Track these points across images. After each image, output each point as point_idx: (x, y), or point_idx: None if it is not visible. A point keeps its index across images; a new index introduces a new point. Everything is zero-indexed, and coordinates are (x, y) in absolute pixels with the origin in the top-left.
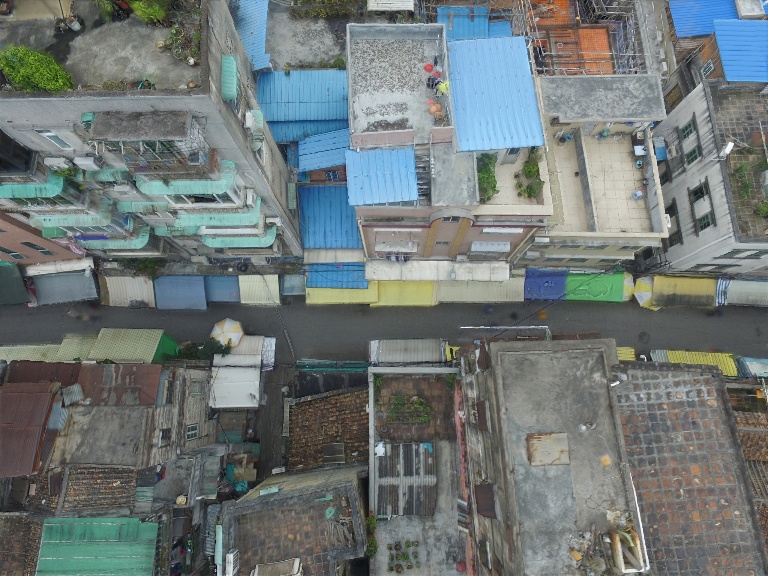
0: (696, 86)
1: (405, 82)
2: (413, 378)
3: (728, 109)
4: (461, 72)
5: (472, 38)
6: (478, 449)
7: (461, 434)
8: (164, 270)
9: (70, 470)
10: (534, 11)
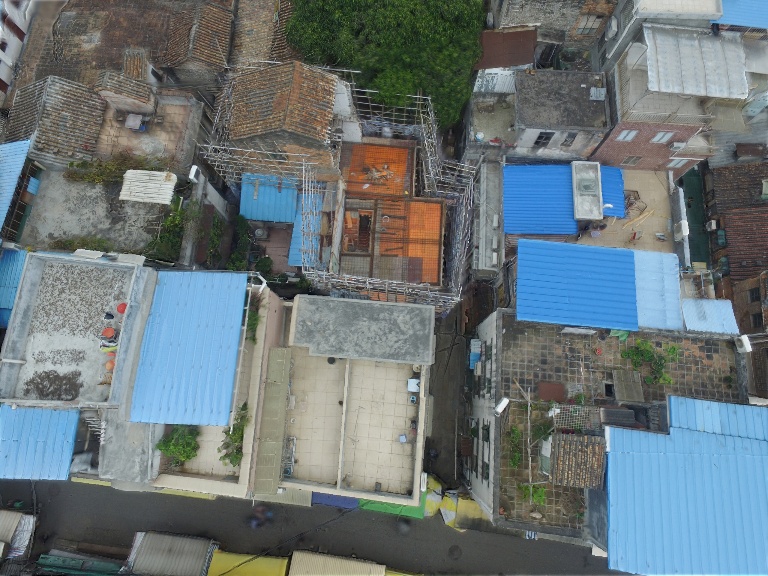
0: (510, 298)
1: (91, 323)
2: None
3: (521, 347)
4: (163, 314)
5: (191, 268)
6: None
7: None
8: None
9: None
10: (365, 176)
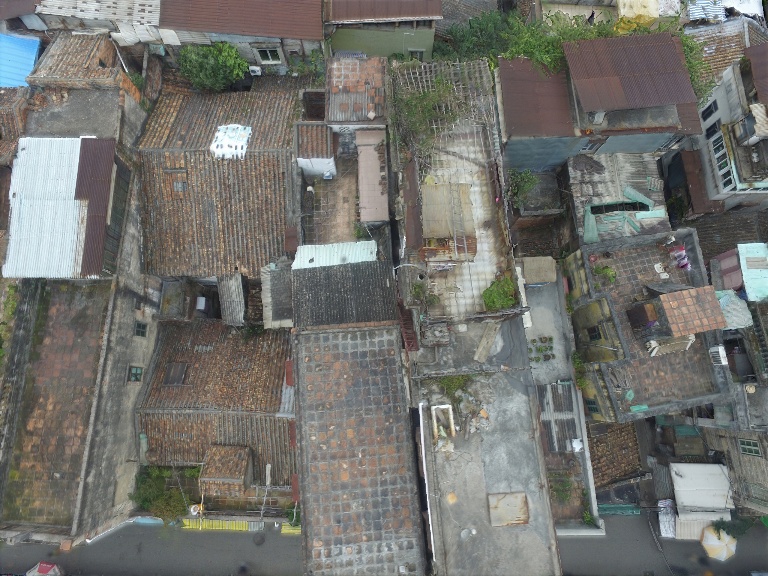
0: None
1: None
2: None
3: None
4: None
5: None
6: None
7: None
8: None
9: None
10: None
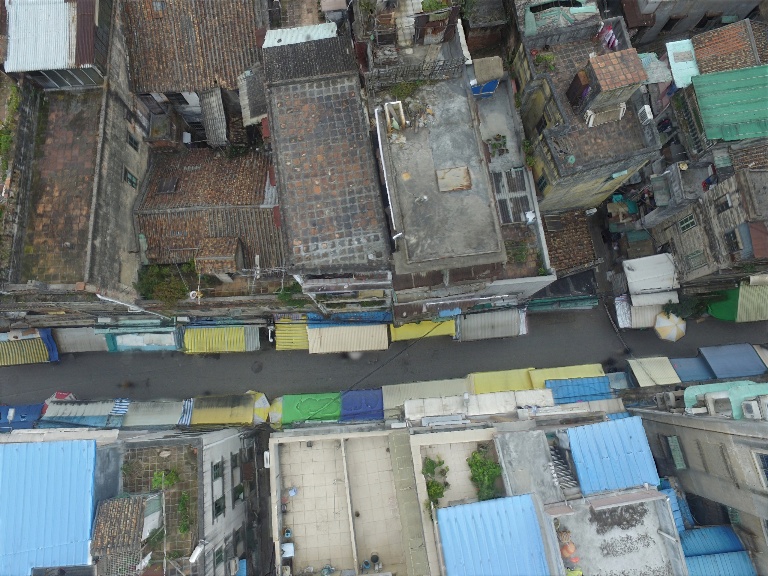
0: None
1: None
2: None
3: None
4: None
5: None
6: None
7: None
8: (763, 380)
9: None
10: None
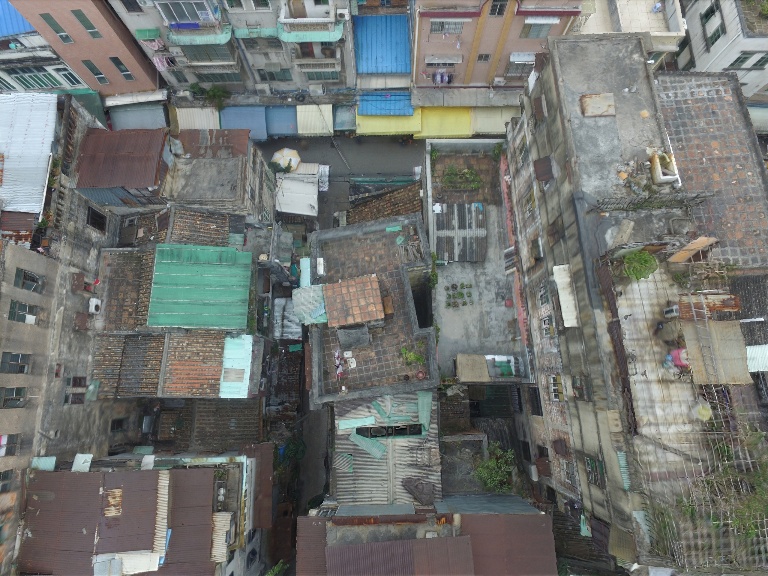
0: None
1: None
2: (463, 156)
3: None
4: None
5: None
6: (529, 172)
7: (507, 194)
8: (230, 101)
9: (175, 210)
10: None
